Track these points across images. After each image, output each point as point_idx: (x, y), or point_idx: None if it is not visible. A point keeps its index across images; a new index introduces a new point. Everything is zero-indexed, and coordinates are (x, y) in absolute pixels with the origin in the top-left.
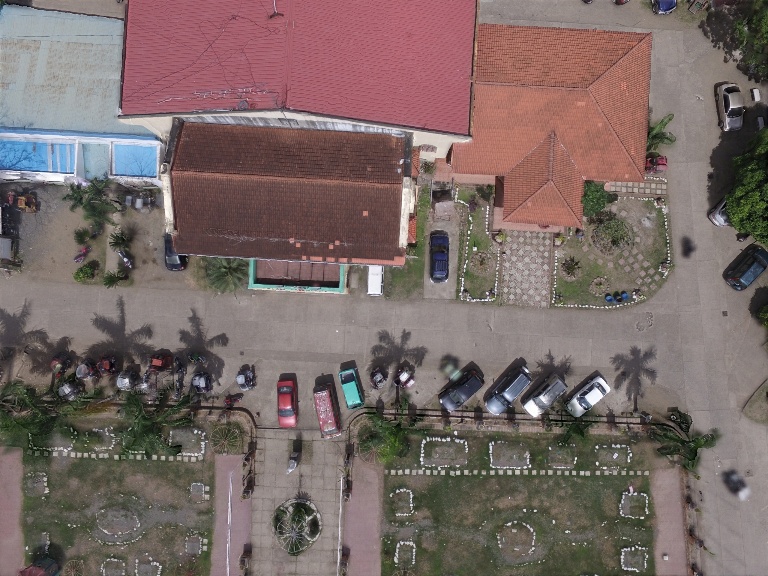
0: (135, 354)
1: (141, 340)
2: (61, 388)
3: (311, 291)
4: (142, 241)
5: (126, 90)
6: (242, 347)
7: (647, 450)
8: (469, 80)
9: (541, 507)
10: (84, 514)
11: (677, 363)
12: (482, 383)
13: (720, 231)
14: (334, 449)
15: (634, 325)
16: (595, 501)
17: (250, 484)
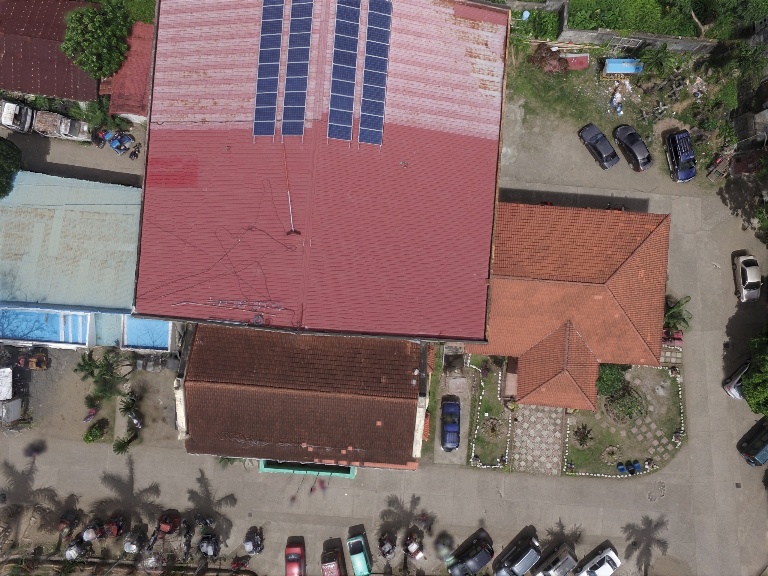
0: (143, 514)
1: (149, 499)
2: (68, 552)
3: None
4: (152, 399)
5: (140, 288)
6: (250, 509)
7: None
8: (486, 283)
9: None
10: None
11: (689, 534)
12: (491, 556)
13: (735, 401)
14: None
15: (646, 495)
16: None
17: None
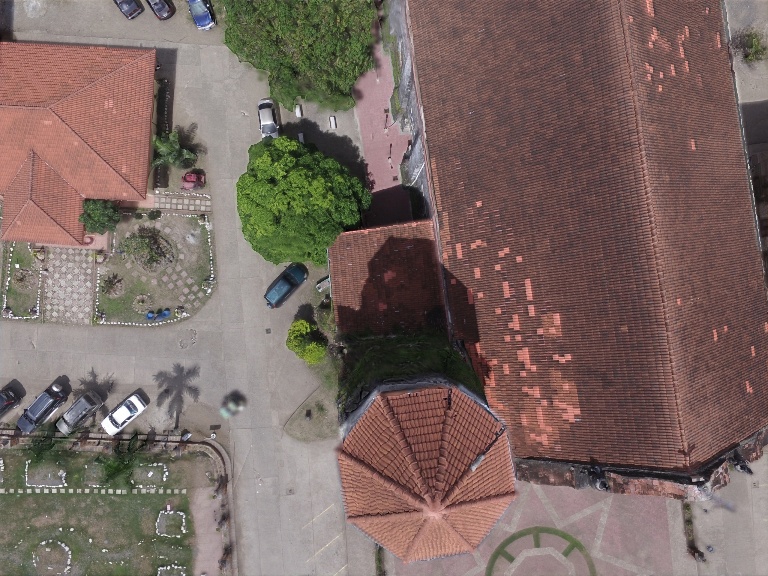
0: None
1: None
2: None
3: None
4: None
5: None
6: None
7: (185, 468)
8: None
9: (79, 526)
10: None
11: (220, 381)
12: (7, 402)
13: None
14: None
15: (177, 342)
16: (133, 520)
17: None
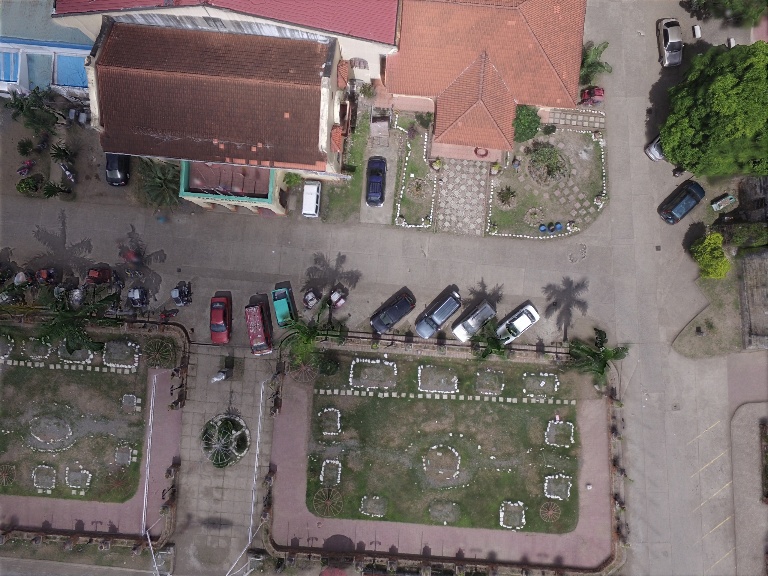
0: (74, 267)
1: (81, 254)
2: None
3: (241, 202)
4: (86, 157)
5: None
6: (179, 264)
7: (575, 380)
8: None
9: (467, 432)
10: (18, 421)
11: (609, 295)
12: (412, 305)
13: (656, 166)
14: (265, 367)
15: (567, 256)
16: (521, 428)
17: (181, 398)
